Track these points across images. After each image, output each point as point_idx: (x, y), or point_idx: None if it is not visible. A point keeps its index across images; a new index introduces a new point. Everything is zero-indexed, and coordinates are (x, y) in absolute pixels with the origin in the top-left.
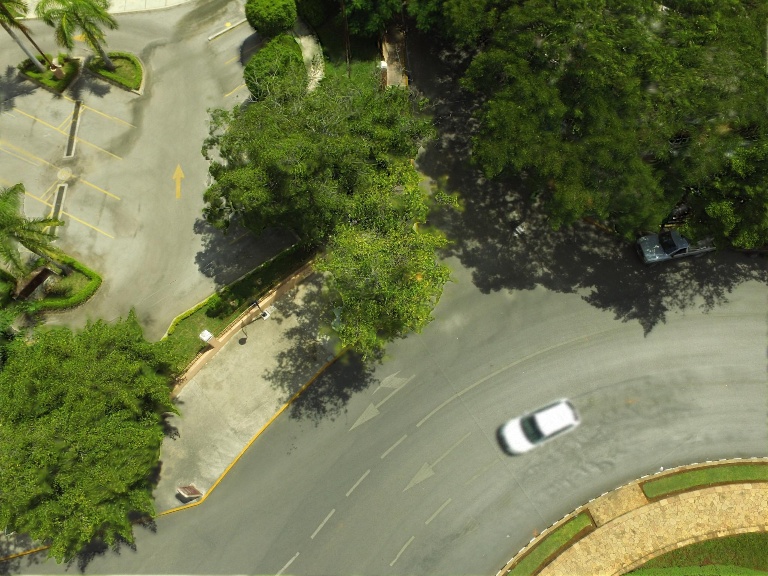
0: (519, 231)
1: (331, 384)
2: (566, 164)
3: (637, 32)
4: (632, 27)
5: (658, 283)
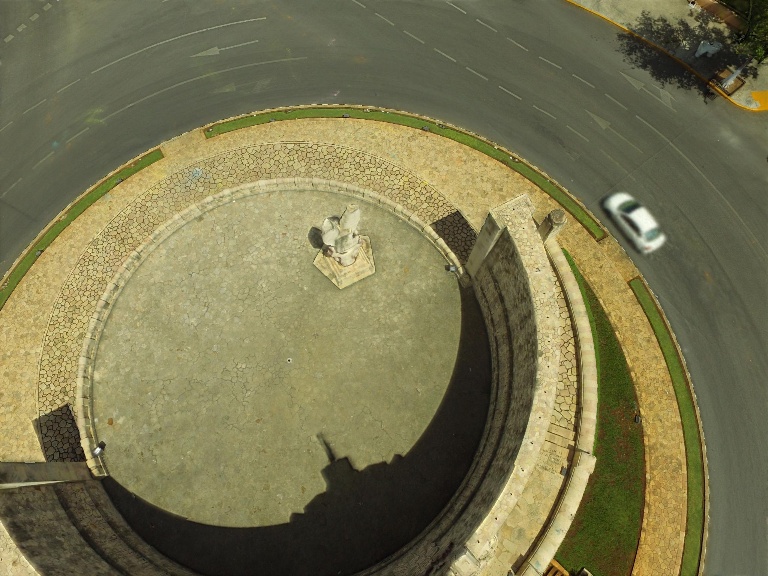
0: None
1: (651, 56)
2: None
3: None
4: None
5: None
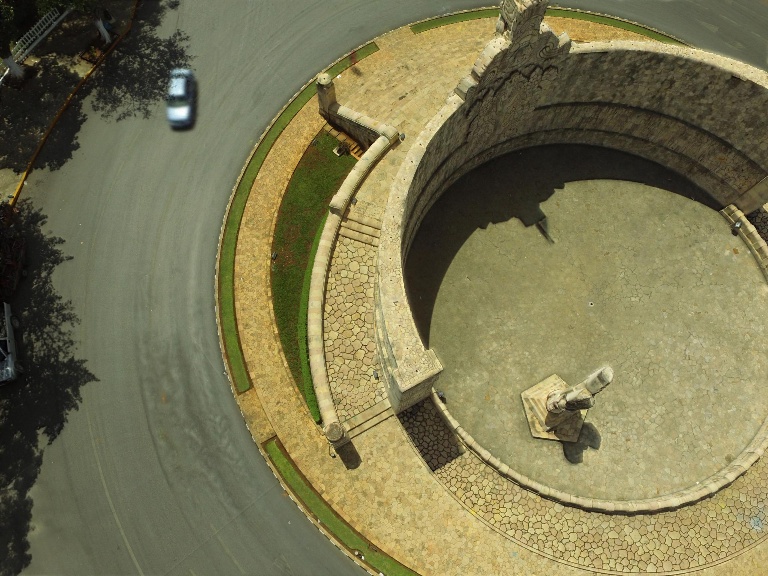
0: None
1: None
2: None
3: None
4: None
5: (43, 364)
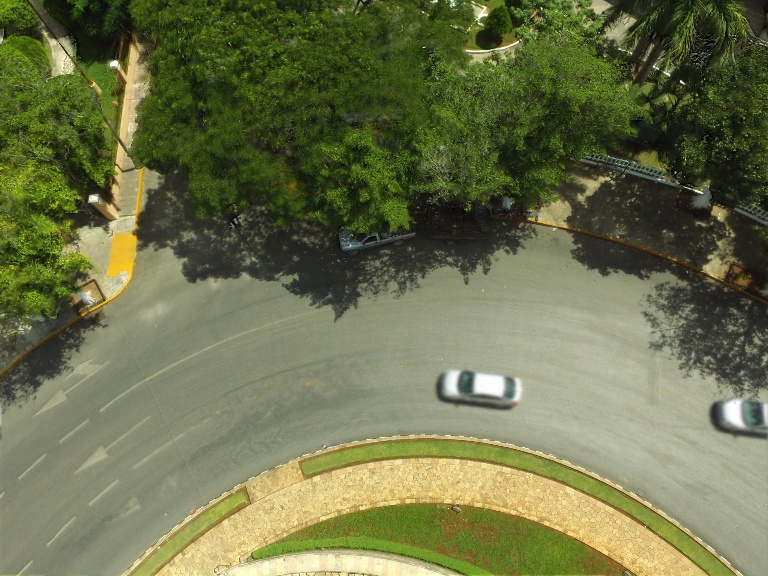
0: (236, 222)
1: (26, 372)
2: (194, 154)
3: (249, 28)
4: (243, 23)
5: (357, 270)
